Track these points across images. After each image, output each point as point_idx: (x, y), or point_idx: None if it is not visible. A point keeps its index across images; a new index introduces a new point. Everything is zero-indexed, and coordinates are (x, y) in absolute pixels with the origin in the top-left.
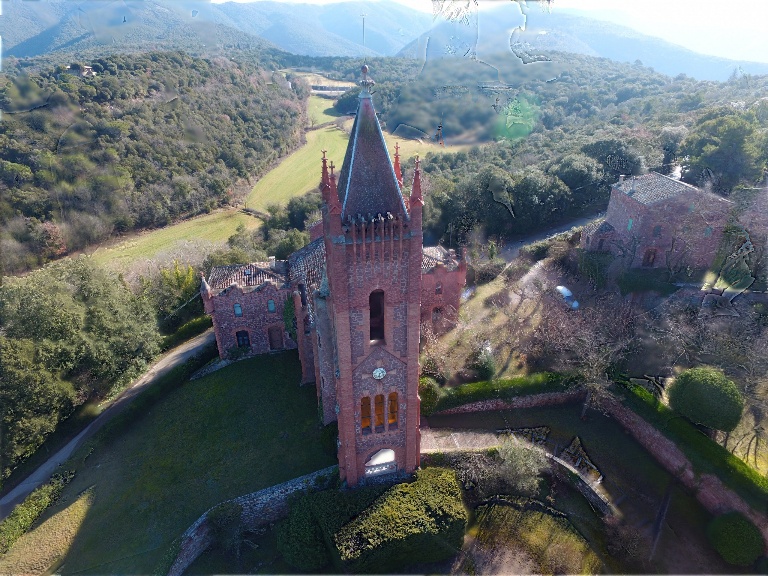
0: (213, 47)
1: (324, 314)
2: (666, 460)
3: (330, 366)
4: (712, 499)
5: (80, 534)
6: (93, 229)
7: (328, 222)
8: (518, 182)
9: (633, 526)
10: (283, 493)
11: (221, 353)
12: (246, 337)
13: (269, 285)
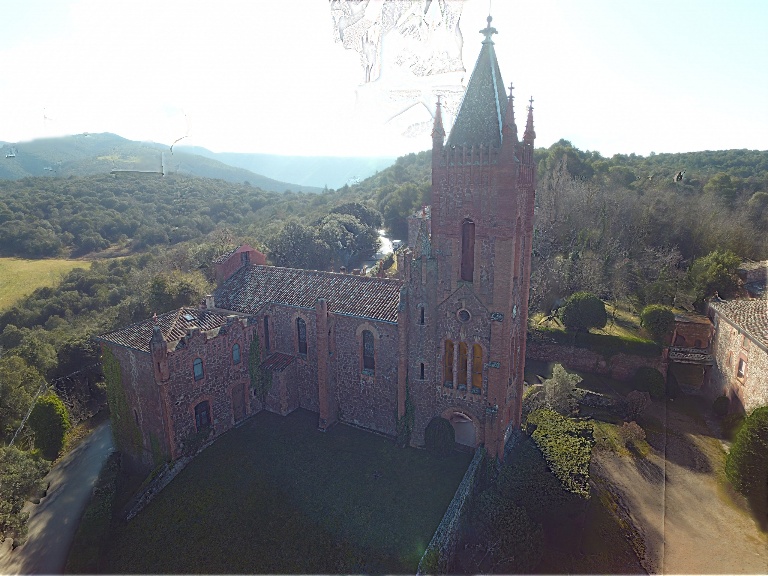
0: None
1: (433, 278)
2: (584, 365)
3: (434, 344)
4: (622, 371)
5: None
6: None
7: (491, 149)
8: (319, 232)
9: (634, 391)
10: (459, 508)
11: (173, 450)
12: (204, 412)
13: (235, 323)
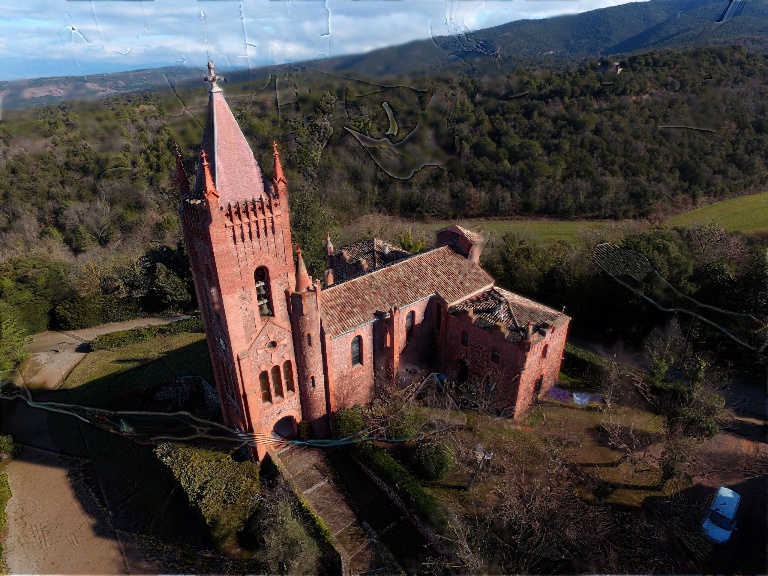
0: (565, 43)
1: None
2: None
3: None
4: None
5: (185, 347)
6: (415, 193)
7: None
8: None
9: None
10: None
11: None
12: None
13: None
